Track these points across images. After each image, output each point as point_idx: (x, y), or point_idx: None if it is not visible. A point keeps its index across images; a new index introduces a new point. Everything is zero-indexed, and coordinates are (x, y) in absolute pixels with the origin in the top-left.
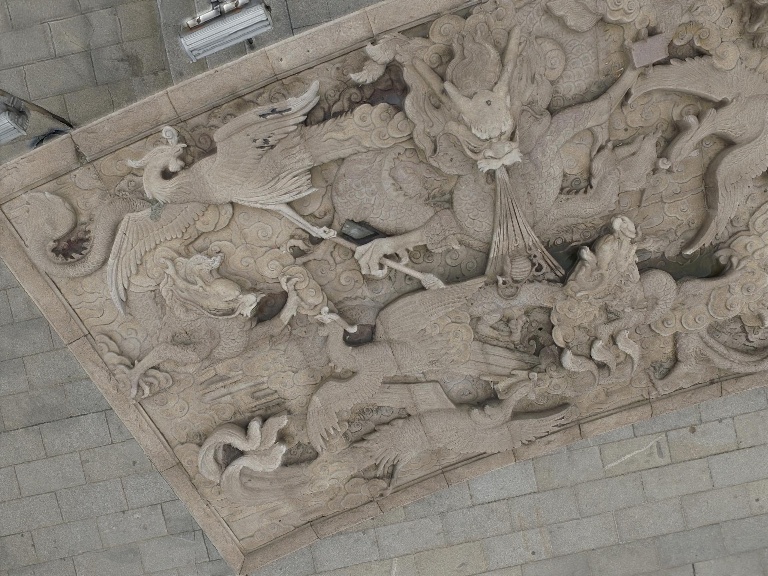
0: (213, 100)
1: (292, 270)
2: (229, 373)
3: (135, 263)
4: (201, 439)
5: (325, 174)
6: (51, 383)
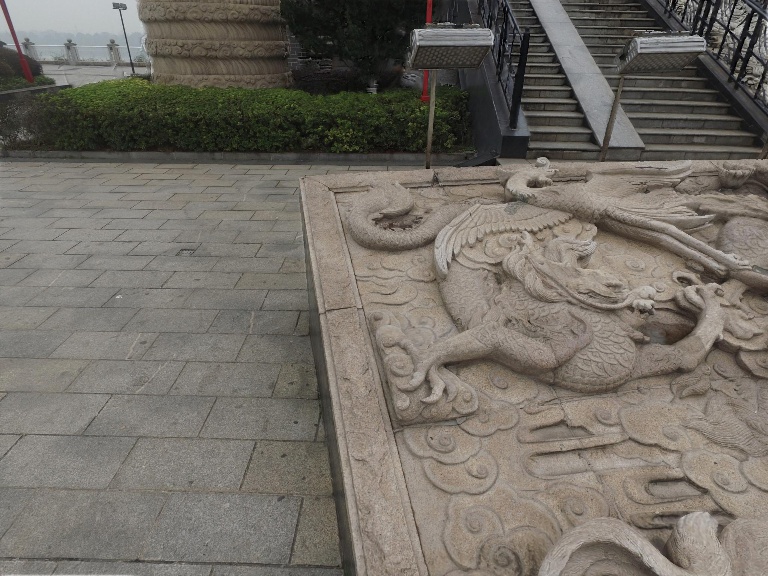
0: (572, 174)
1: (698, 285)
2: (591, 424)
3: (475, 236)
4: (520, 570)
5: (703, 233)
6: (152, 486)
